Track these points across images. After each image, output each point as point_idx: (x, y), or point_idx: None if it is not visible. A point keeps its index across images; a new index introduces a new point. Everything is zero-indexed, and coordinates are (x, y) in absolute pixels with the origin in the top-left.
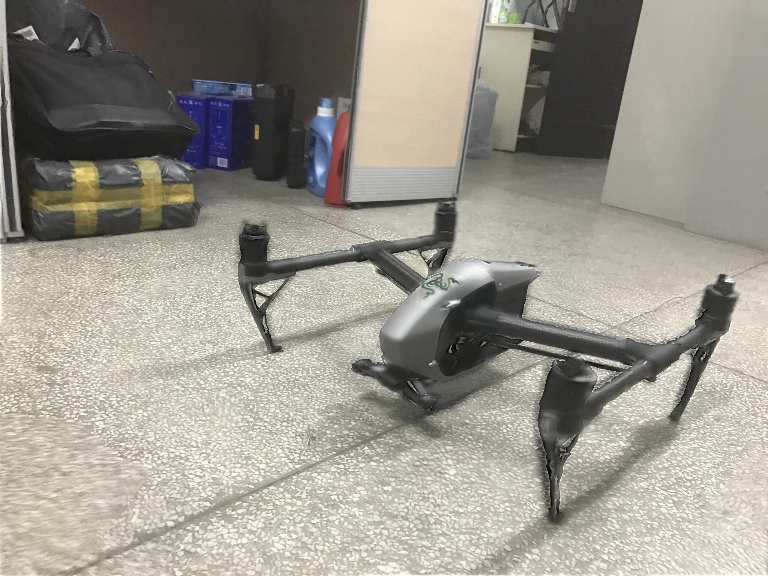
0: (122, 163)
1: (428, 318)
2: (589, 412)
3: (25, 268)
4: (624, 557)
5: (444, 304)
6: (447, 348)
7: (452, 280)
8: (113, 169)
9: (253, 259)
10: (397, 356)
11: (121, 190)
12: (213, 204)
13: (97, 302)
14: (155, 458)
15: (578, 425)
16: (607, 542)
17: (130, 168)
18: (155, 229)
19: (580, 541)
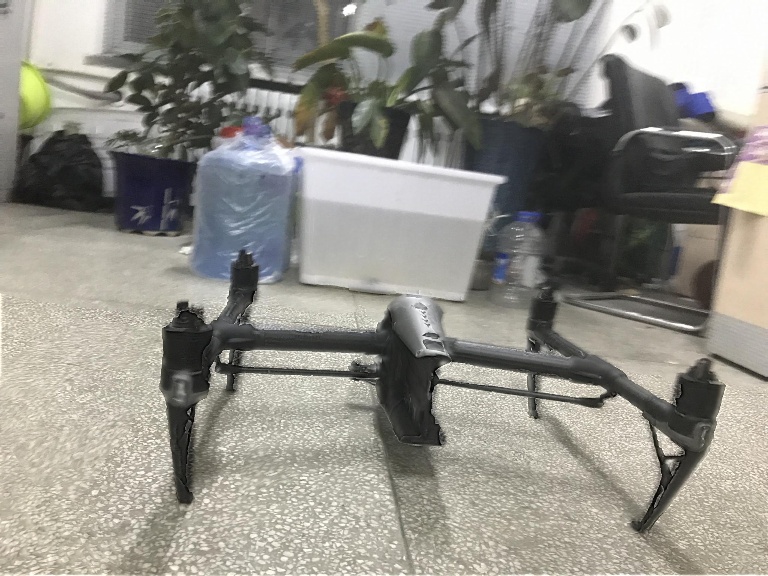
0: None
1: None
2: None
3: (760, 405)
4: None
5: None
6: None
7: None
8: None
9: None
10: None
11: None
12: None
13: None
14: None
15: None
16: None
17: None
18: None
19: None
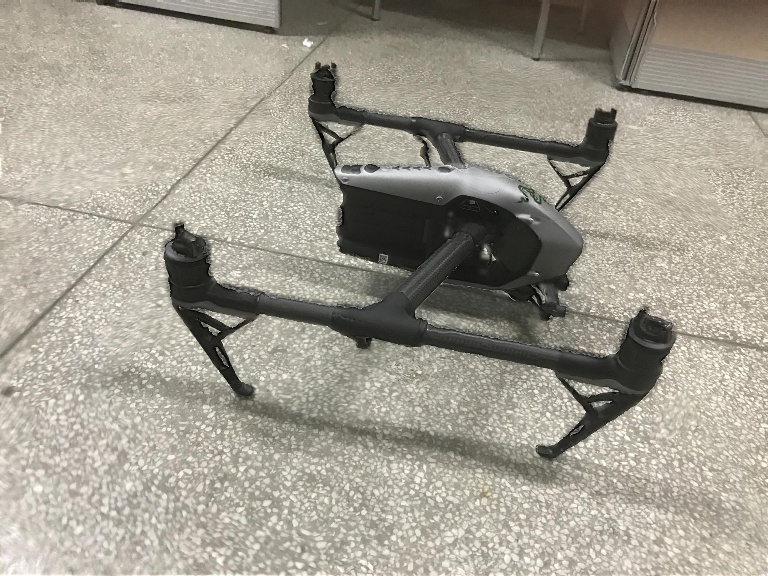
0: None
1: None
2: None
3: None
4: None
5: None
6: None
7: None
8: None
9: None
10: None
11: None
12: None
13: None
14: (767, 404)
15: None
16: None
17: None
18: None
19: None
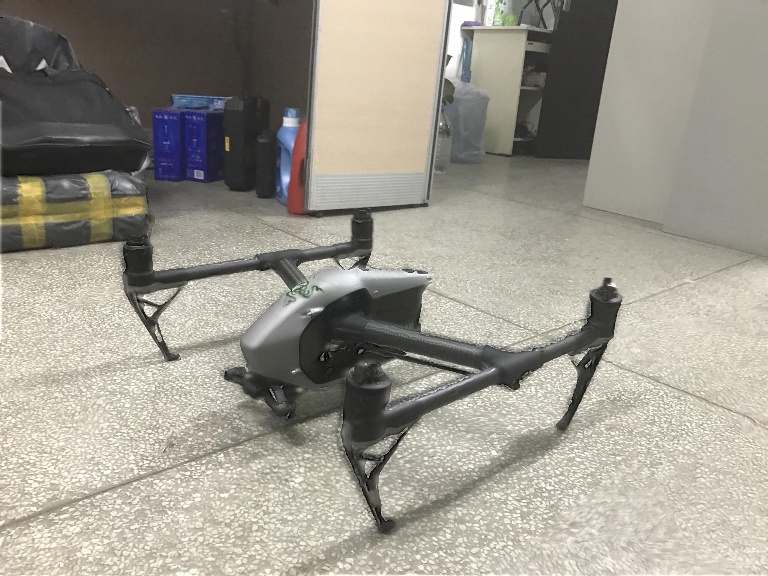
0: (71, 177)
1: (286, 326)
2: (398, 419)
3: None
4: (441, 568)
5: (305, 312)
6: (318, 356)
7: (316, 288)
8: (61, 183)
9: (136, 269)
10: (255, 364)
11: (68, 203)
12: (177, 216)
13: (16, 312)
14: (2, 464)
15: (376, 432)
16: (431, 552)
17: (78, 182)
18: (106, 241)
19: (402, 551)
